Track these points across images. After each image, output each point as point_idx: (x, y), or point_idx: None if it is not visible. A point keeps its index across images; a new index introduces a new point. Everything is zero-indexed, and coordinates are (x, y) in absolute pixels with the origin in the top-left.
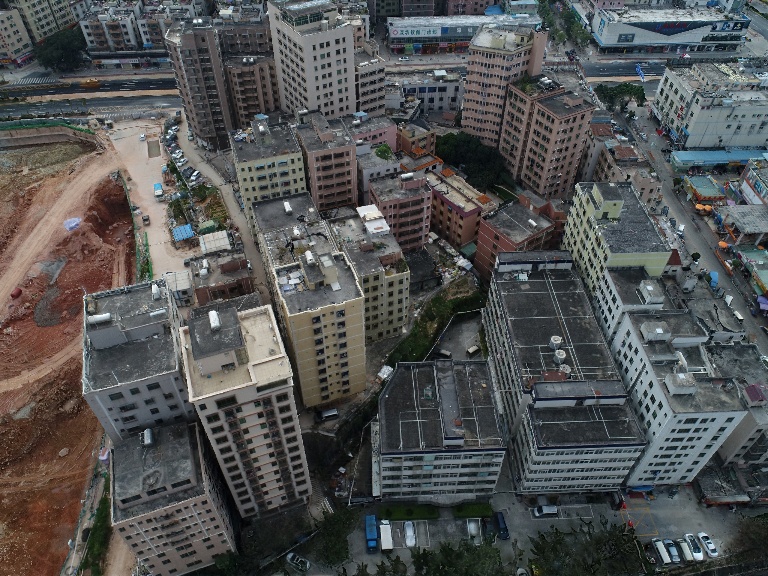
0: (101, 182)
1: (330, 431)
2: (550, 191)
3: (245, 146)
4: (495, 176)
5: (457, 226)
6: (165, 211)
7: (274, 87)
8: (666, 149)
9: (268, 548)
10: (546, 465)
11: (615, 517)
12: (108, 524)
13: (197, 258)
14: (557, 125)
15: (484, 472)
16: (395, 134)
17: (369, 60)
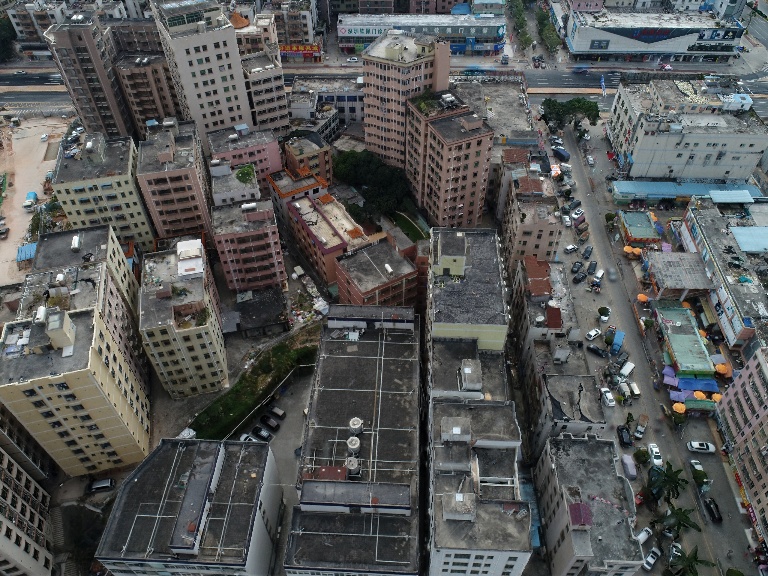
0: None
1: (96, 506)
2: (452, 223)
3: (72, 164)
4: (395, 202)
5: (321, 262)
6: (29, 224)
7: (173, 90)
8: (611, 177)
9: None
10: None
11: None
12: None
13: None
14: (446, 152)
15: None
16: (277, 151)
17: (267, 65)
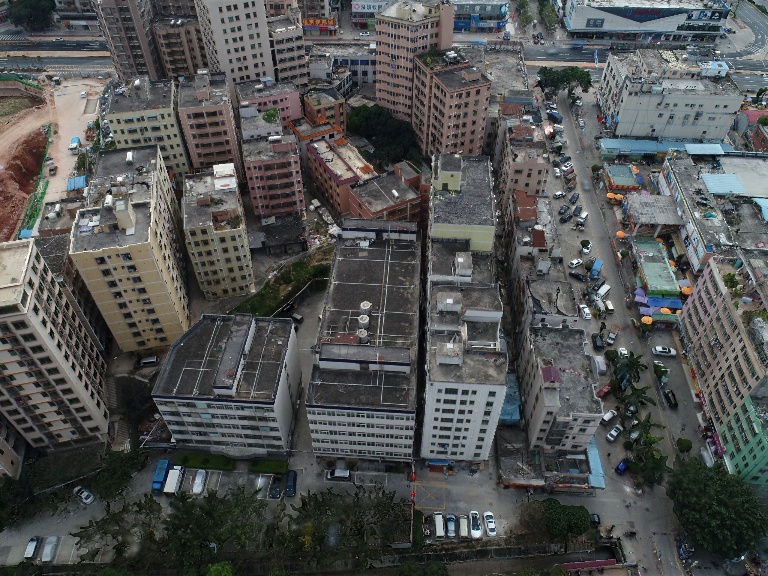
0: (31, 134)
1: (145, 377)
2: None
3: (122, 100)
4: (402, 150)
5: (336, 194)
6: (75, 163)
7: (203, 51)
8: (599, 136)
9: (54, 478)
10: (323, 425)
11: (407, 488)
12: None
13: (53, 203)
14: (448, 99)
15: (264, 426)
16: (298, 101)
17: None
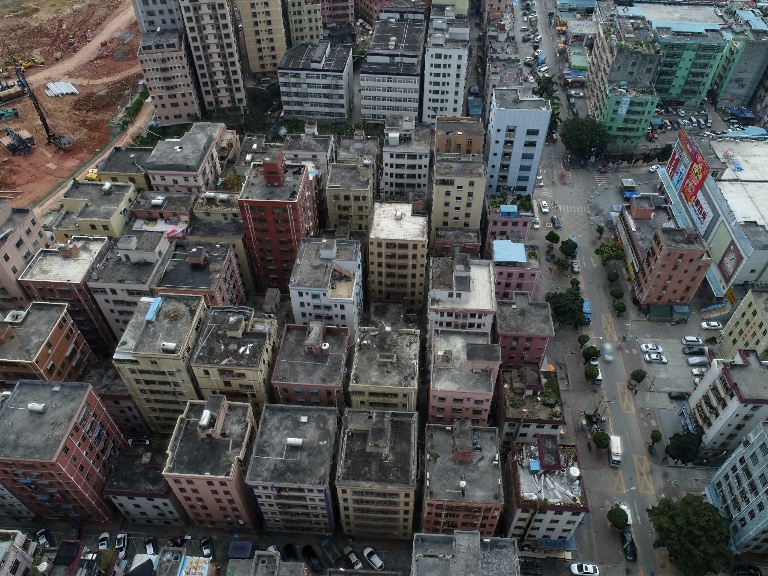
0: None
1: (264, 87)
2: None
3: None
4: None
5: (374, 12)
6: None
7: None
8: None
9: None
10: (369, 91)
11: None
12: (139, 106)
13: None
14: None
15: (336, 95)
16: None
17: None
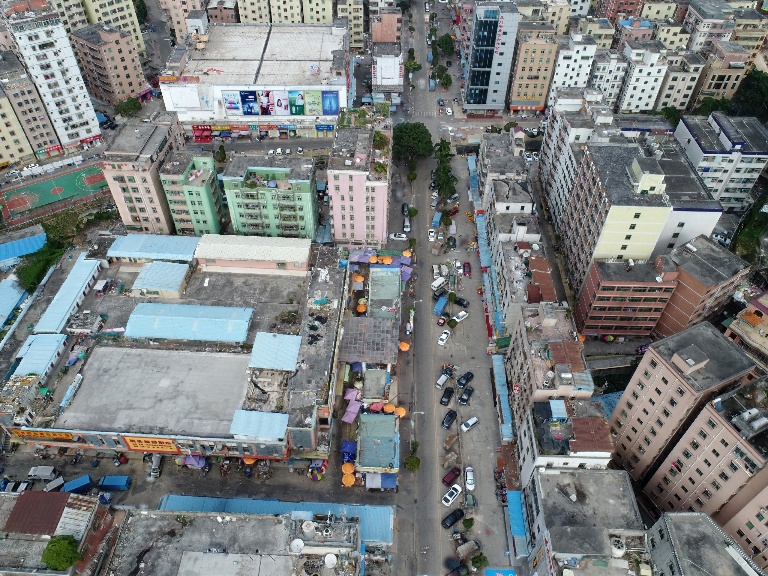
0: None
1: None
2: None
3: None
4: None
5: None
6: None
7: None
8: None
9: None
10: None
11: None
12: None
13: None
14: None
15: None
16: None
17: None
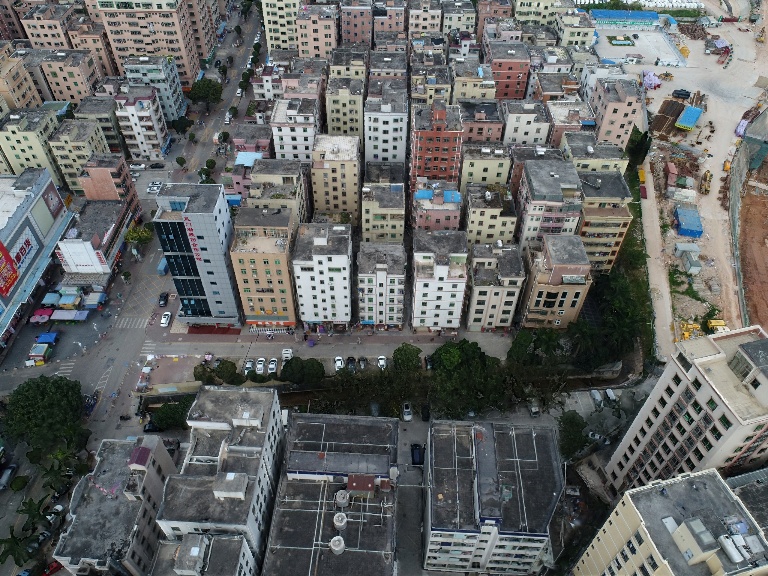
0: None
1: None
2: None
3: None
4: None
5: None
6: None
7: None
8: None
9: None
10: None
11: None
12: None
13: None
14: None
15: None
16: None
17: None
